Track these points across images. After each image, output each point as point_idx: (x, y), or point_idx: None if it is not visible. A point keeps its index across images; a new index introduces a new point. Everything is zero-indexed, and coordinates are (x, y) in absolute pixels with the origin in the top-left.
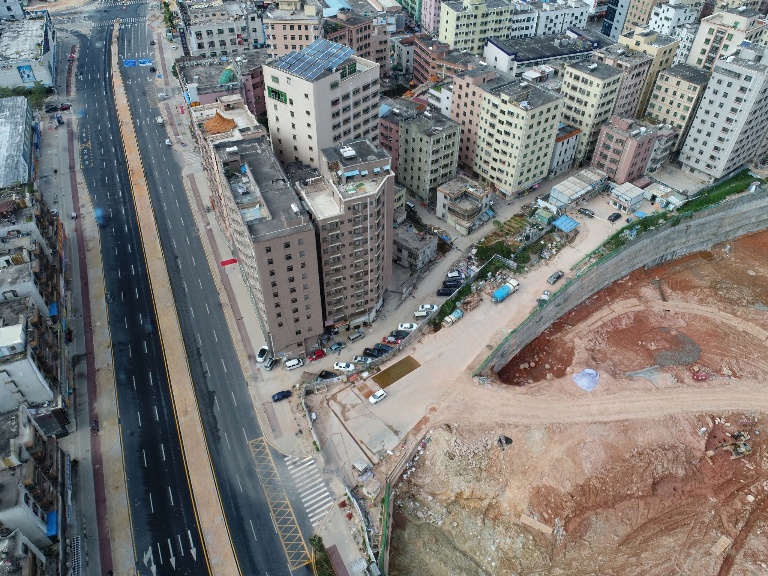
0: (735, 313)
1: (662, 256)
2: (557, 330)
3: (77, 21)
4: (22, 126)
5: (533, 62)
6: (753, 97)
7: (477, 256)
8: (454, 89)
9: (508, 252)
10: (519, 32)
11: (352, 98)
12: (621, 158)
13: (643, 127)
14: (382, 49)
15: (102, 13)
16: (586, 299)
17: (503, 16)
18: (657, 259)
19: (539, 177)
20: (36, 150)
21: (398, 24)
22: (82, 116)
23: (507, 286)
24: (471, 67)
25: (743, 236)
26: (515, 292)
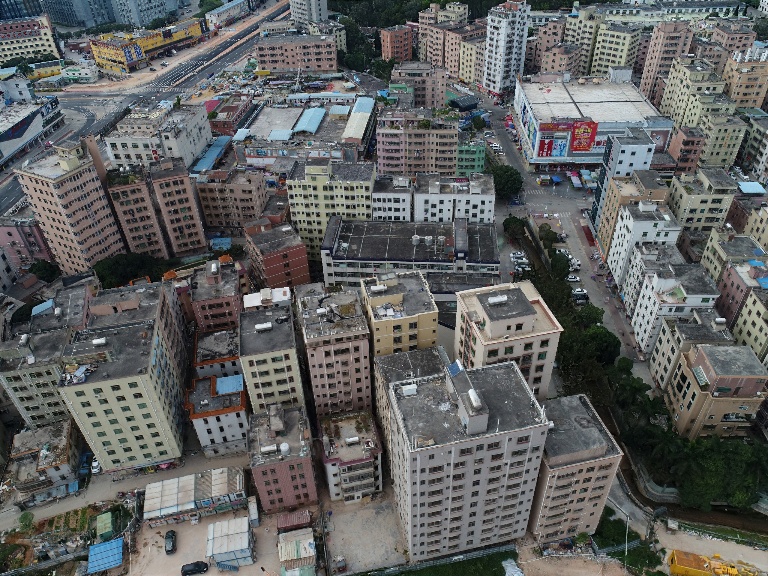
0: None
1: None
2: None
3: (107, 104)
4: None
5: (358, 262)
6: (408, 474)
7: None
8: None
9: None
10: (386, 213)
11: None
12: None
13: (284, 444)
14: (247, 198)
15: (135, 98)
16: None
17: (356, 192)
18: None
19: (162, 457)
20: None
21: (348, 158)
22: None
23: None
24: None
25: None
26: None
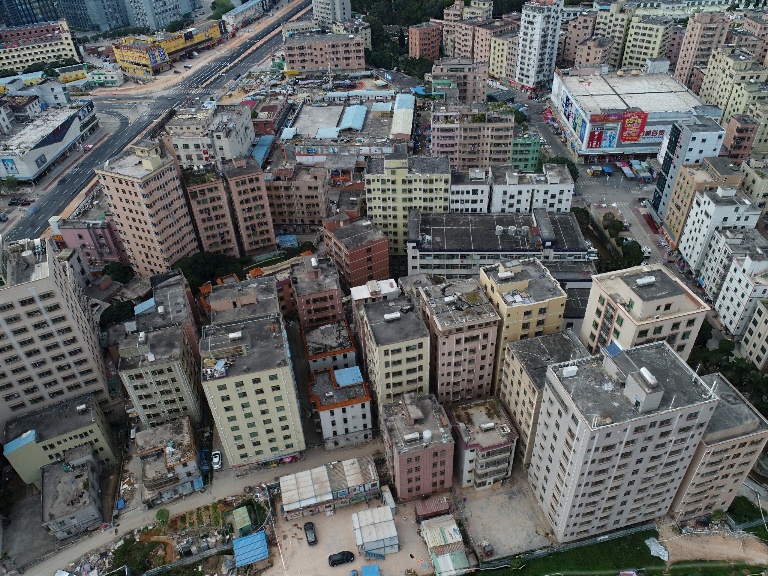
0: None
1: None
2: None
3: (138, 107)
4: None
5: (445, 254)
6: (581, 453)
7: (115, 554)
8: None
9: (141, 569)
10: (463, 205)
11: (1, 314)
12: (395, 464)
13: (427, 431)
14: (313, 195)
15: (166, 101)
16: None
17: (435, 185)
18: None
19: (288, 450)
20: None
21: None
22: (29, 215)
23: None
24: None
25: None
26: None
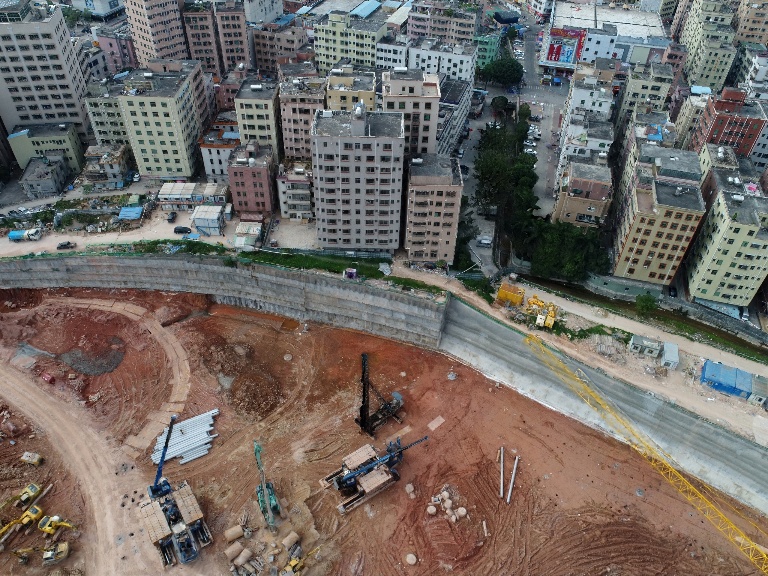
0: (194, 370)
1: (240, 299)
2: (54, 293)
3: None
4: None
5: None
6: None
7: None
8: None
9: None
10: (386, 63)
11: (17, 42)
12: None
13: (252, 158)
14: (290, 48)
15: None
16: (115, 288)
17: (365, 41)
18: (232, 298)
19: (179, 174)
20: None
21: None
22: None
23: (24, 231)
24: None
25: (354, 330)
26: (33, 241)
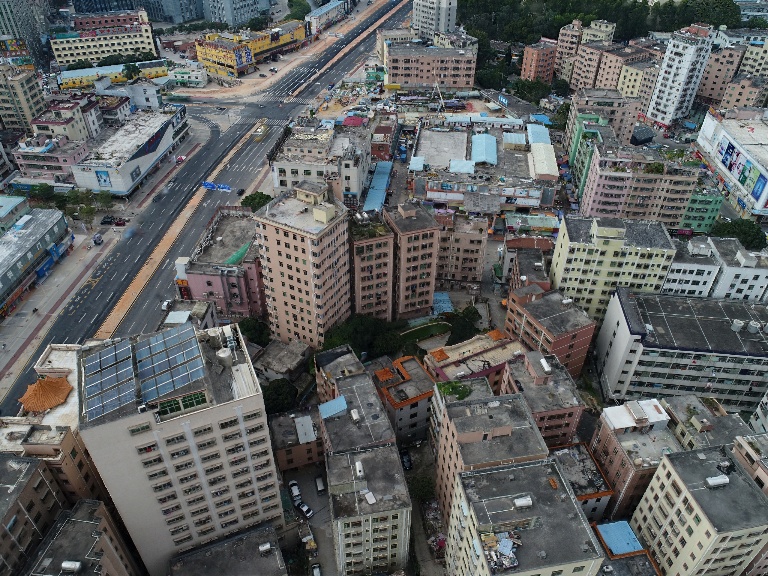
0: None
1: None
2: None
3: (227, 114)
4: (21, 254)
5: (675, 352)
6: None
7: None
8: (443, 422)
9: None
10: (680, 285)
11: (194, 438)
12: None
13: None
14: (473, 249)
15: (257, 108)
16: None
17: (653, 260)
18: None
19: None
20: (45, 274)
21: (545, 198)
22: (126, 238)
23: None
24: (527, 361)
25: None
26: None
